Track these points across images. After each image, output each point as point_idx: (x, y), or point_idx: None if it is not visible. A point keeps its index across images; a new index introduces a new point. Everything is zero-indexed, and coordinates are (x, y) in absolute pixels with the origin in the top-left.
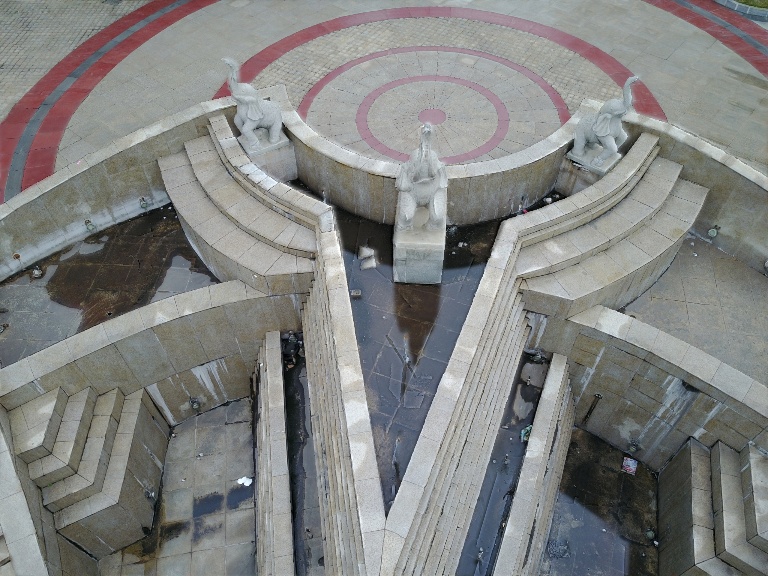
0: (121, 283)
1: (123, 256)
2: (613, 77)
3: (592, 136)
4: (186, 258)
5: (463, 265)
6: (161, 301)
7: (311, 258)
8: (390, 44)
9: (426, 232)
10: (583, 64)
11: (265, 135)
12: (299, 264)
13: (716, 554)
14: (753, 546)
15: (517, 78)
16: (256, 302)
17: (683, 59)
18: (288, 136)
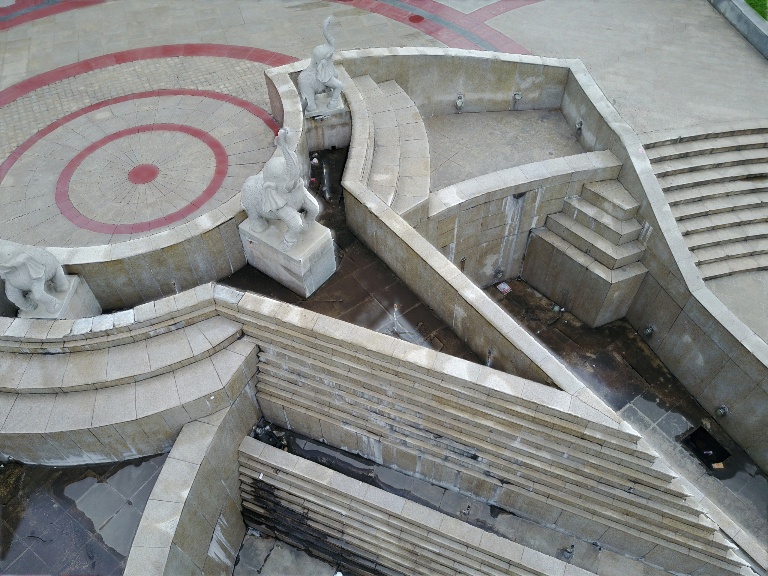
0: (45, 571)
1: (2, 553)
2: (230, 56)
3: (319, 86)
4: (78, 480)
5: None
6: (144, 516)
7: (239, 338)
8: (4, 149)
9: (307, 233)
10: (196, 61)
11: (46, 291)
12: (237, 351)
13: (611, 269)
14: (621, 245)
15: (164, 101)
16: (224, 423)
17: (255, 17)
18: (71, 273)
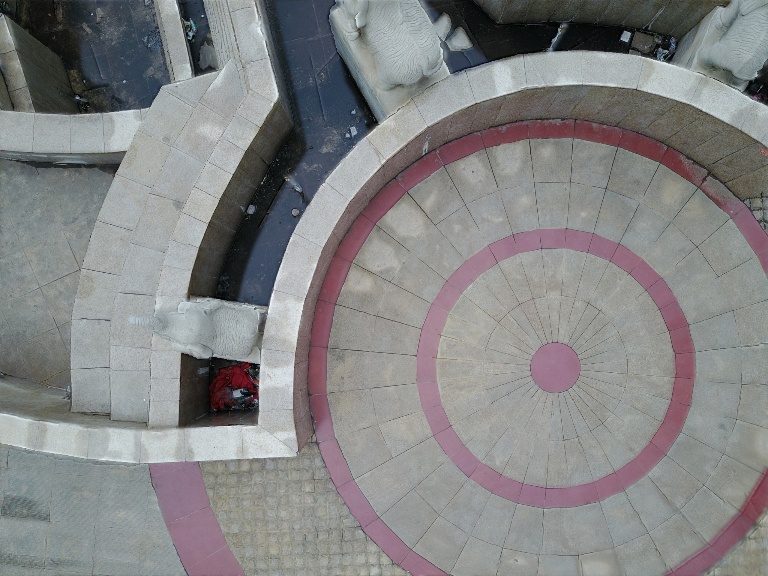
0: None
1: None
2: None
3: None
4: None
5: (331, 100)
6: None
7: None
8: None
9: None
10: None
11: None
12: None
13: None
14: None
15: (487, 569)
16: None
17: None
18: None
